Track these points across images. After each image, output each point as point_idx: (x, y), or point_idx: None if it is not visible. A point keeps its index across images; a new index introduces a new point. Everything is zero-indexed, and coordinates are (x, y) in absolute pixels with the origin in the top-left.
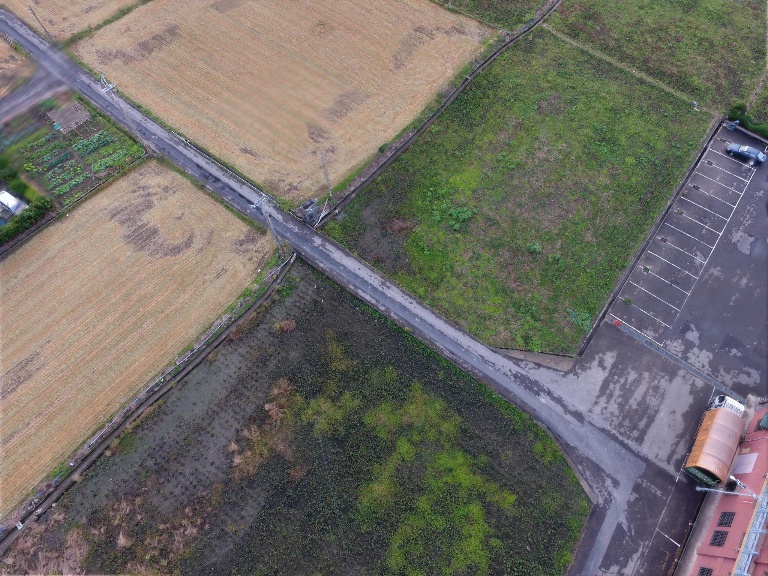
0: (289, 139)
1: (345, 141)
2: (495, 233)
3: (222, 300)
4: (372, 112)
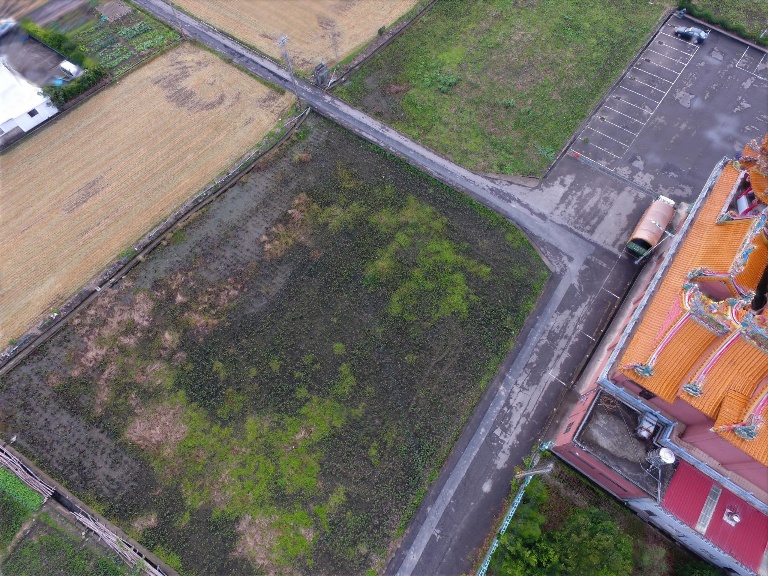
0: (301, 27)
1: (349, 28)
2: (476, 94)
3: (250, 140)
4: (372, 6)
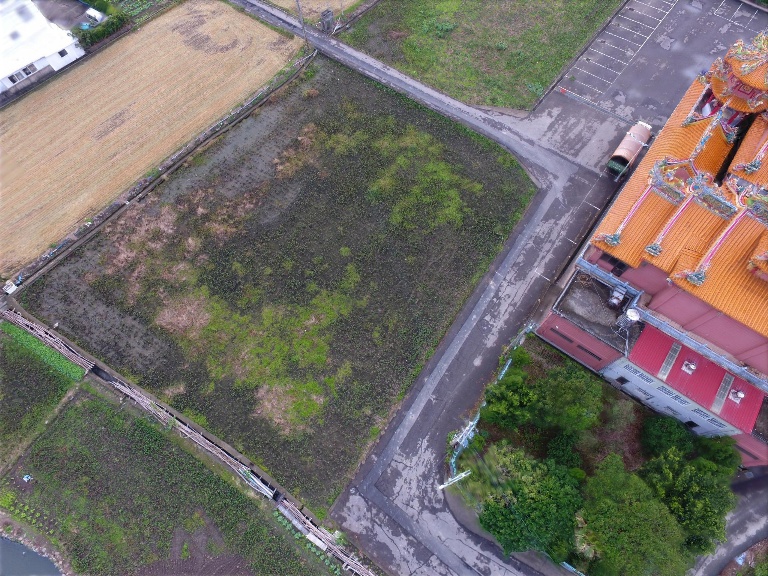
0: None
1: None
2: (471, 38)
3: (262, 78)
4: None
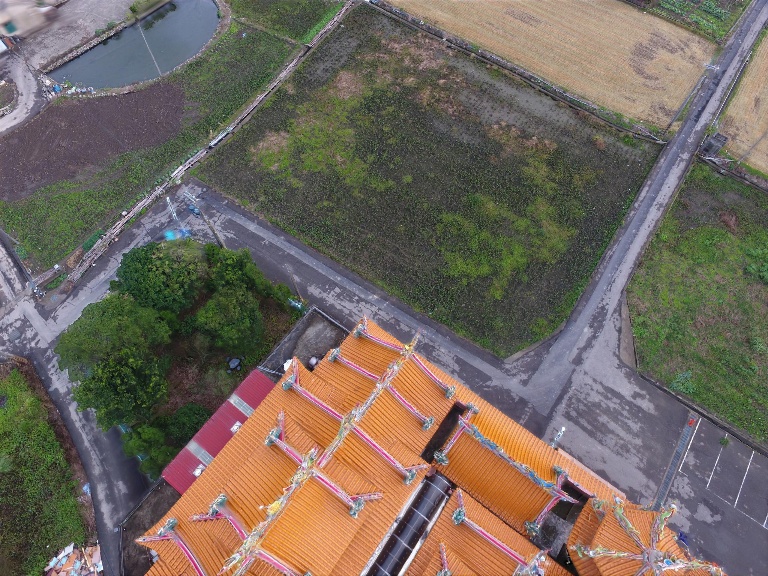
0: None
1: None
2: (759, 307)
3: (608, 103)
4: None
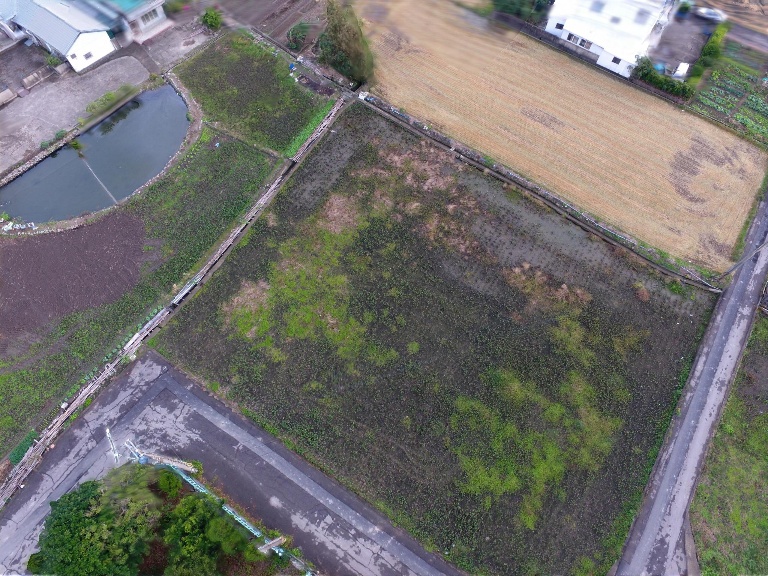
0: None
1: None
2: None
3: (649, 236)
4: None
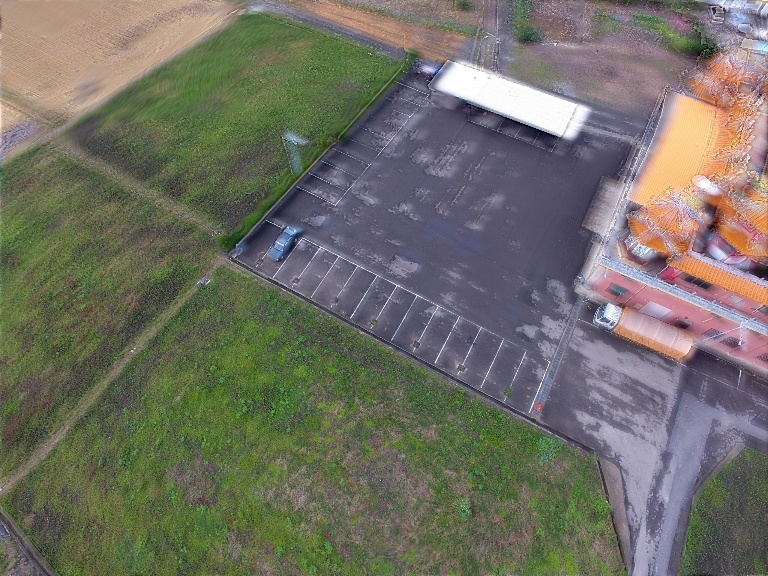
0: None
1: None
2: (453, 570)
3: None
4: None
